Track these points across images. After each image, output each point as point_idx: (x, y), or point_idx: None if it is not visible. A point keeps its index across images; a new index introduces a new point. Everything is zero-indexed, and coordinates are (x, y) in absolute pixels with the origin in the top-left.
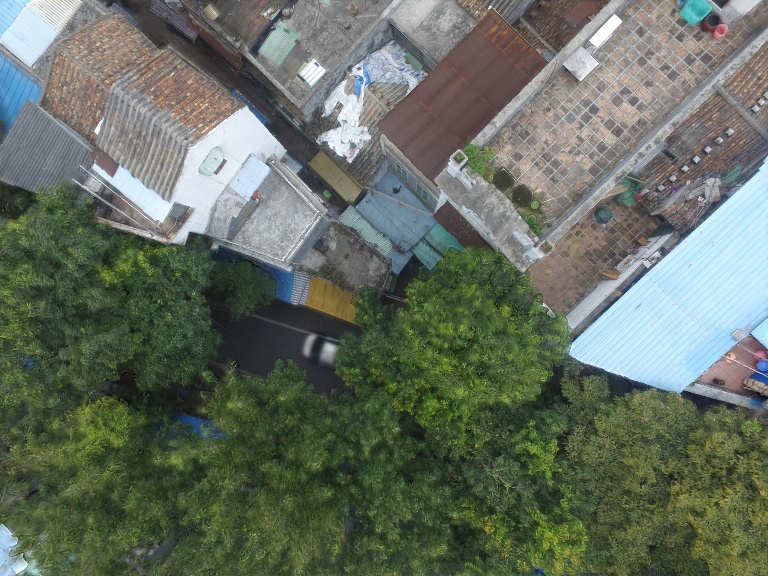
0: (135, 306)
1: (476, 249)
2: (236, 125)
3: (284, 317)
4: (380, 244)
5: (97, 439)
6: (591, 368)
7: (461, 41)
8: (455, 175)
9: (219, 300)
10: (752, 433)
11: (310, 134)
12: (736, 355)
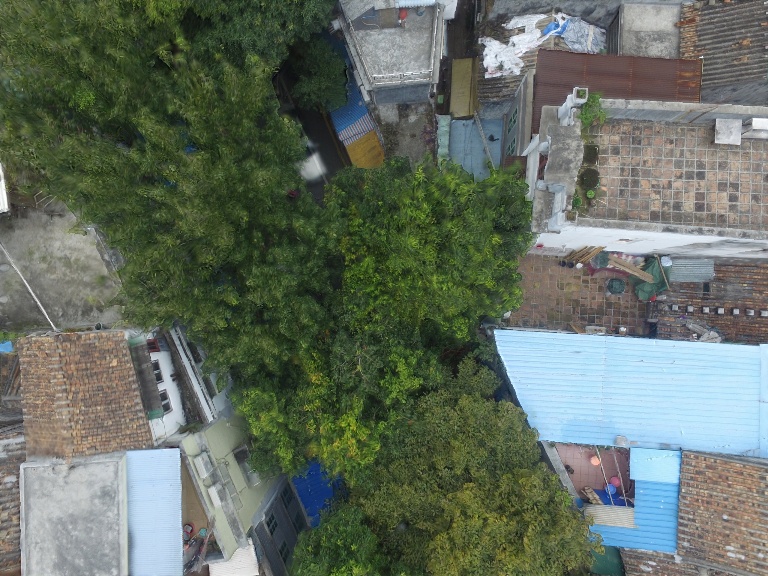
0: None
1: None
2: None
3: (319, 149)
4: None
5: None
6: (498, 363)
7: (657, 58)
8: (561, 115)
9: (292, 80)
10: (561, 501)
11: (480, 29)
12: None
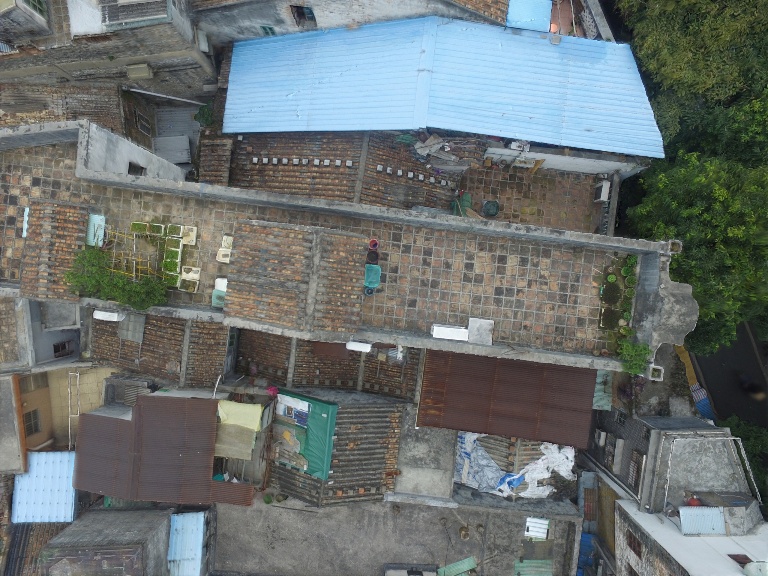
0: None
1: (714, 301)
2: (712, 573)
3: None
4: None
5: None
6: None
7: None
8: None
9: None
10: None
11: (575, 489)
12: None
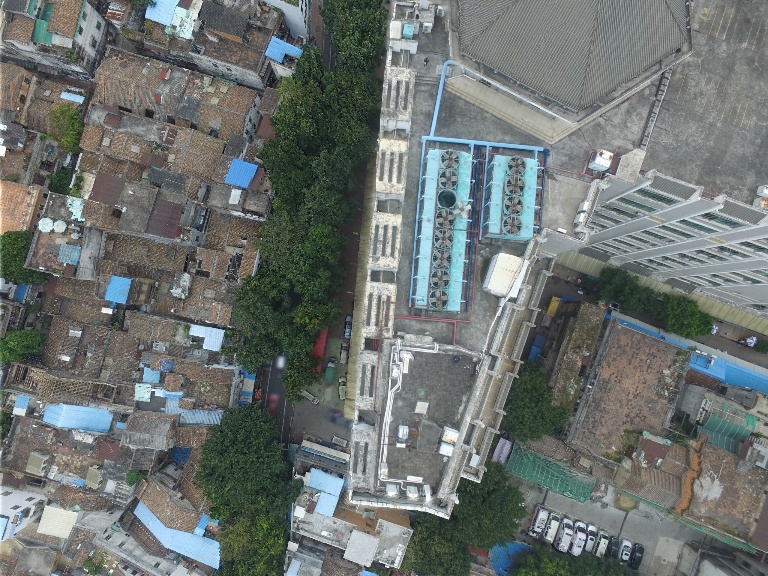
0: None
1: None
2: None
3: None
4: None
5: None
6: None
7: None
8: None
9: None
10: None
11: None
12: None
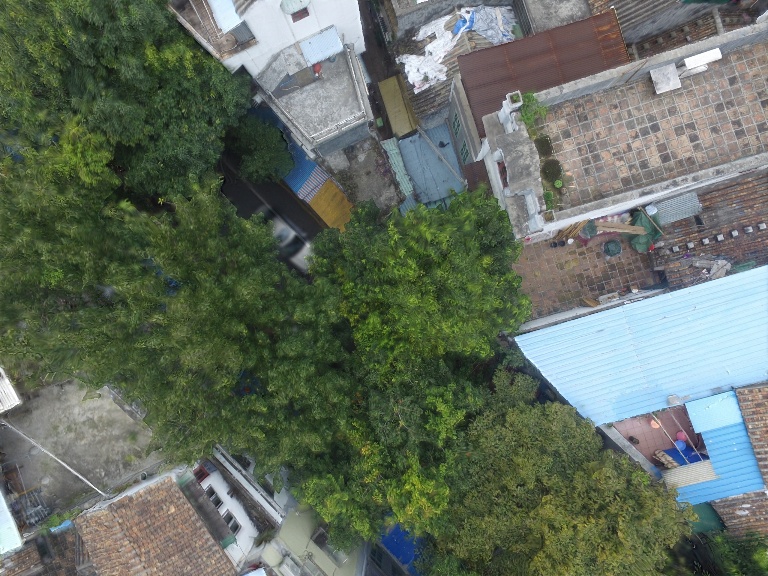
0: (161, 100)
1: None
2: None
3: (284, 211)
4: (403, 185)
5: (68, 165)
6: (530, 367)
7: (571, 23)
8: (503, 120)
9: (235, 159)
10: (639, 482)
11: (394, 50)
12: (662, 425)
